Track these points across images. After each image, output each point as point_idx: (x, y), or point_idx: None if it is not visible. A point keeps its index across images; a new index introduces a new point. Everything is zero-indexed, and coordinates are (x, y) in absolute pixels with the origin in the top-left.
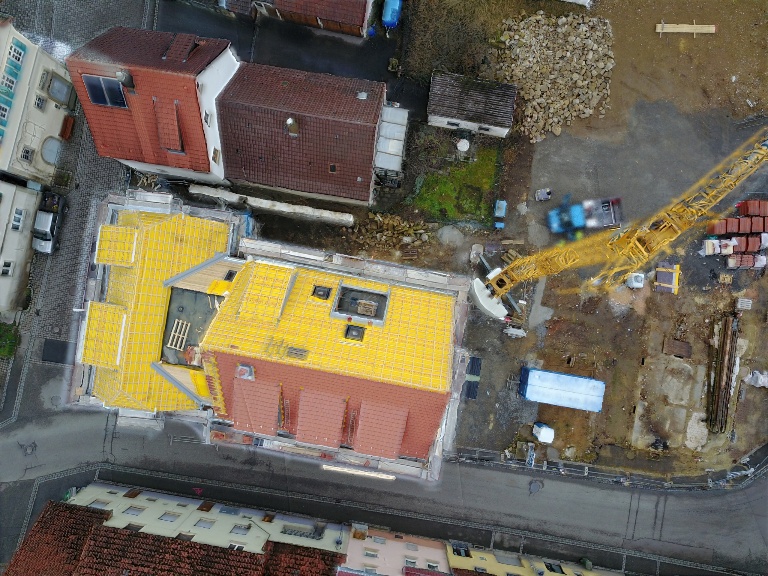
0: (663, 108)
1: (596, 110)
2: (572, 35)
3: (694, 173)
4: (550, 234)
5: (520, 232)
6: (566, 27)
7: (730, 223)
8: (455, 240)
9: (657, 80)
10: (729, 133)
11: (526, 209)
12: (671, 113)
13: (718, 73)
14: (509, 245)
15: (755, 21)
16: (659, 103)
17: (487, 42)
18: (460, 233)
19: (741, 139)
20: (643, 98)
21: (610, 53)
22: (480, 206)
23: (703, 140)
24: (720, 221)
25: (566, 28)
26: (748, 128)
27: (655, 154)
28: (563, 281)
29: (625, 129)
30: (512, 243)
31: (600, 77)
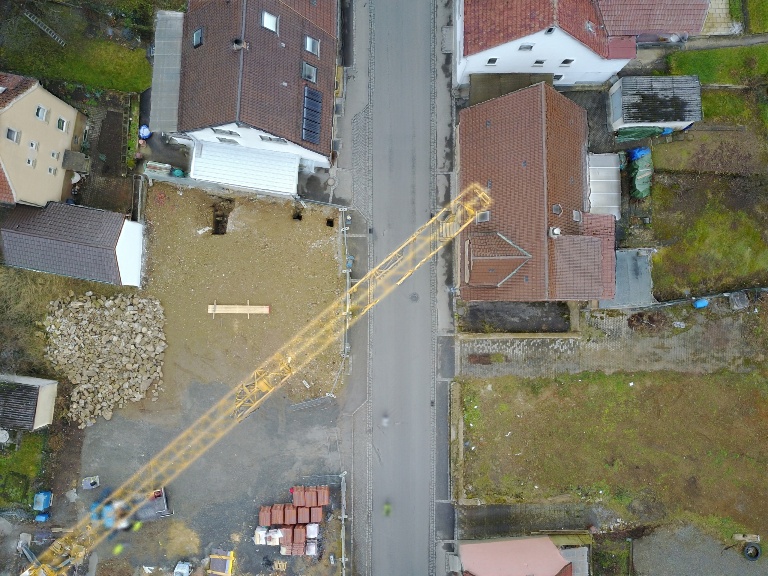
0: (217, 390)
1: (149, 392)
2: (118, 319)
3: (248, 457)
4: (100, 522)
5: (69, 520)
6: (114, 310)
7: (274, 515)
8: (2, 529)
9: (211, 361)
10: (285, 415)
11: (76, 496)
12: (226, 395)
13: (273, 354)
14: (59, 533)
15: (312, 300)
16: (213, 385)
17: (34, 325)
18: (7, 522)
19: (298, 420)
20: (197, 380)
21: (161, 336)
22: (27, 494)
23: (259, 422)
24: (264, 513)
25: (114, 311)
26: (305, 409)
27: (209, 438)
28: (114, 570)
29: (179, 412)
30: (62, 531)
31: (152, 359)
